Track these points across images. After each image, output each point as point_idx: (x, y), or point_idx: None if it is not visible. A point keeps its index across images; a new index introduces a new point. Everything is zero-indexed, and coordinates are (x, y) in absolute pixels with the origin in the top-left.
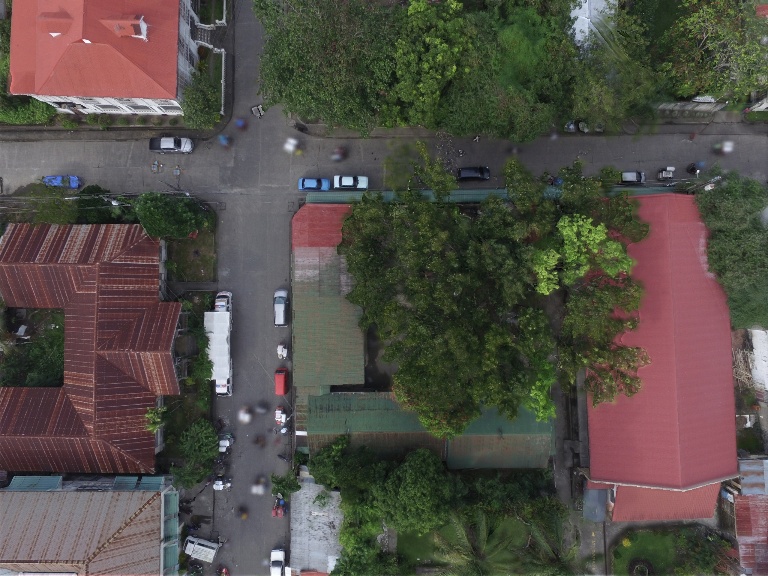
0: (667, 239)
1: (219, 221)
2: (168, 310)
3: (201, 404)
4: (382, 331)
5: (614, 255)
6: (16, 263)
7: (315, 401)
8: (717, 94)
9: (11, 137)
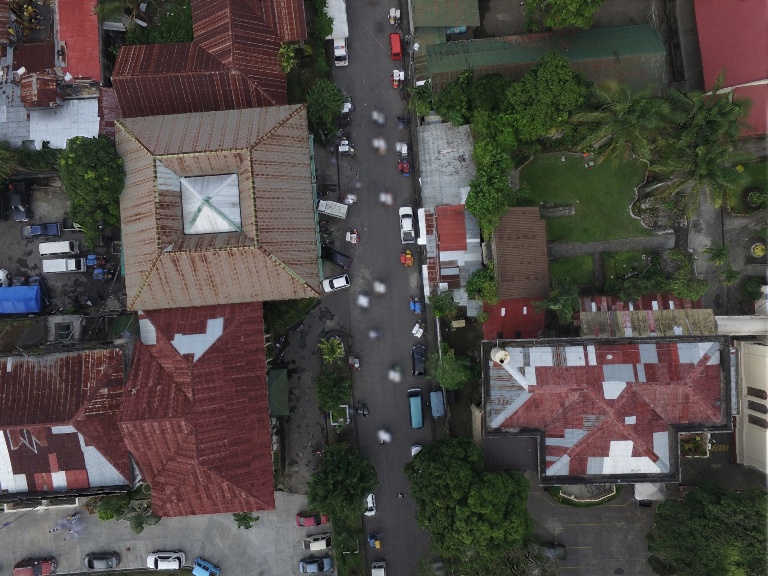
0: None
1: None
2: None
3: (323, 64)
4: None
5: None
6: None
7: (434, 49)
8: None
9: None
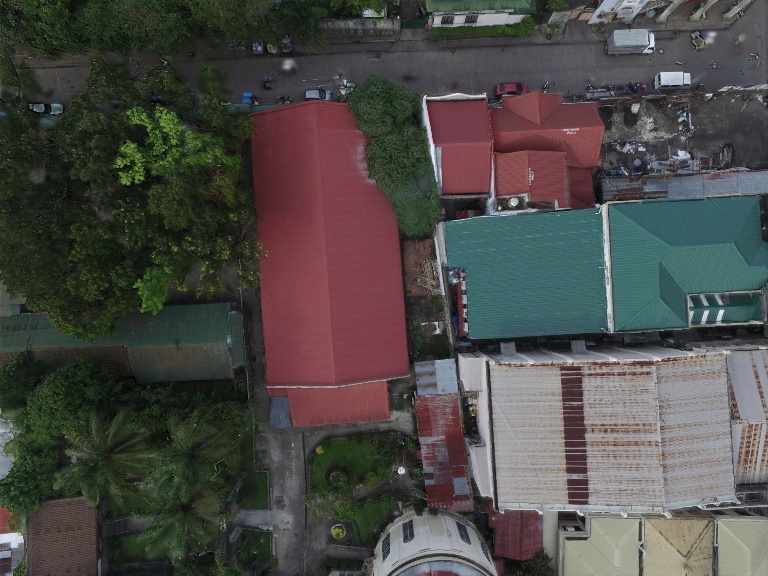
0: (316, 145)
1: None
2: None
3: None
4: None
5: (197, 146)
6: None
7: (3, 322)
8: (376, 7)
9: None
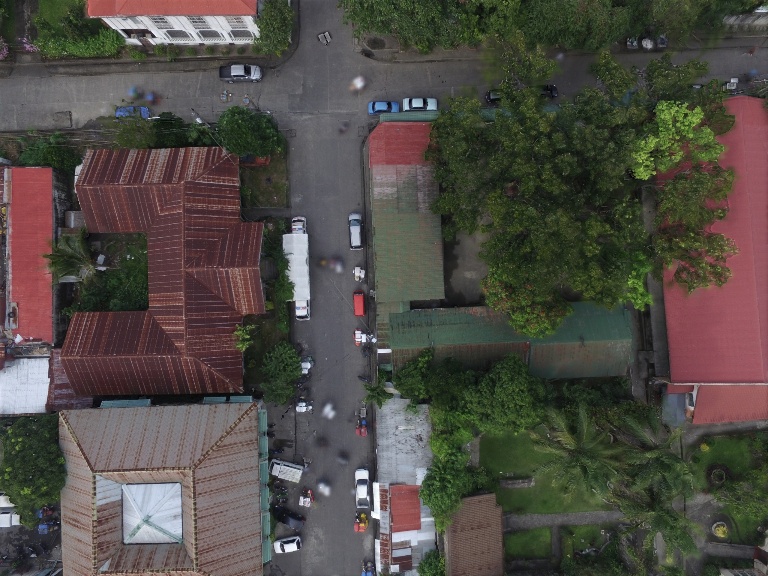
0: (742, 141)
1: (290, 148)
2: (251, 230)
3: (282, 326)
4: (456, 251)
5: (708, 140)
6: (101, 185)
7: (396, 318)
8: None
9: (79, 71)
